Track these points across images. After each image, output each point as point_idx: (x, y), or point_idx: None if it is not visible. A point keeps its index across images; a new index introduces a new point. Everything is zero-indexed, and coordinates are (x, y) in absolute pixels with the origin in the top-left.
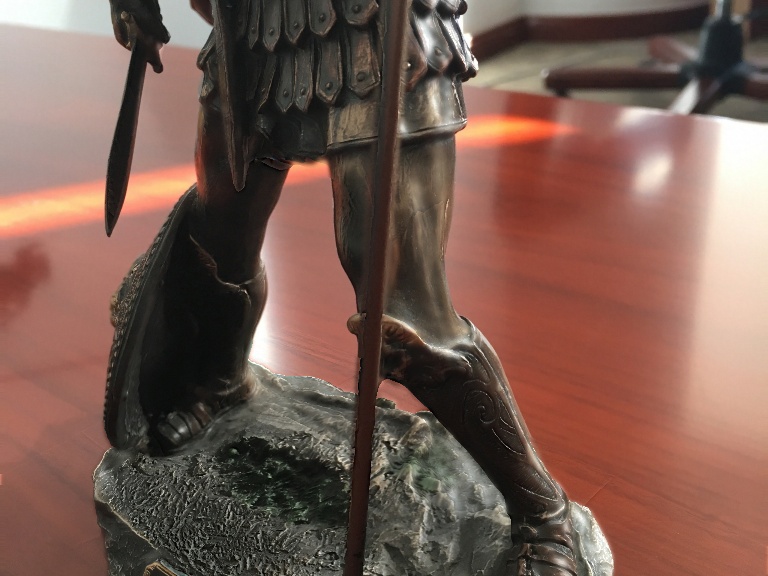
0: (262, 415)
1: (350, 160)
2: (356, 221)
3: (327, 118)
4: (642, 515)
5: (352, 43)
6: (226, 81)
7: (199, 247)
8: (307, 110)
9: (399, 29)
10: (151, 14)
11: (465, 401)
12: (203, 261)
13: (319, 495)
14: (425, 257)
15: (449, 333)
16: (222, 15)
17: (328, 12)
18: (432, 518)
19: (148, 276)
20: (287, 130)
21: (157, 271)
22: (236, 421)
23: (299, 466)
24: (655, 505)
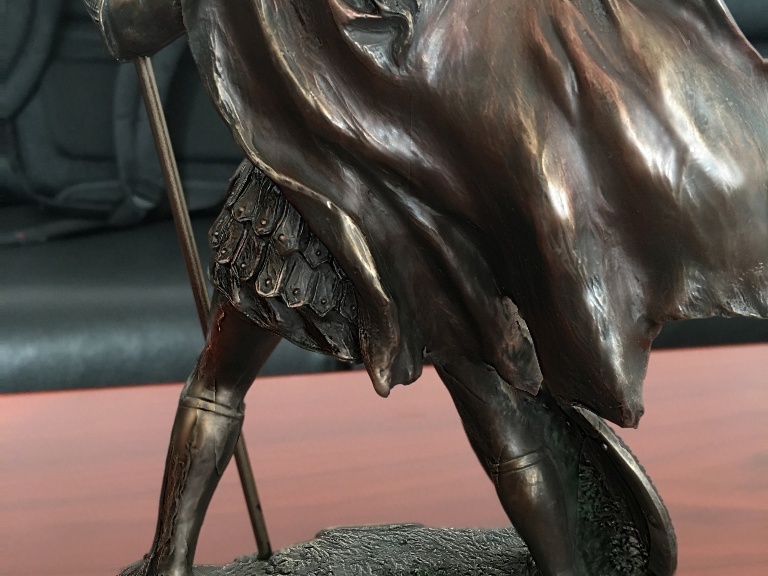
0: None
1: None
2: None
3: None
4: None
5: None
6: None
7: None
8: None
9: None
10: None
11: None
12: None
13: None
14: None
15: None
16: None
17: None
18: None
19: None
20: None
21: None
22: None
23: None
24: None
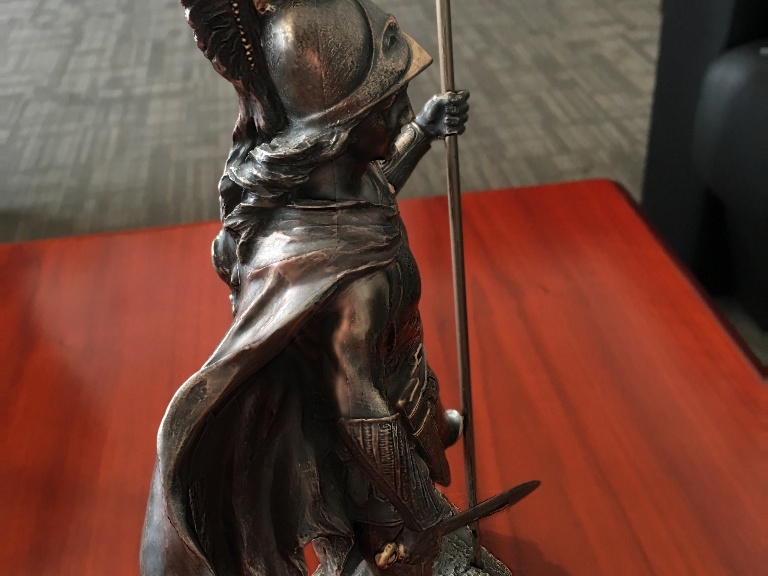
0: None
1: None
2: None
3: None
4: None
5: None
6: None
7: None
8: None
9: None
10: None
11: None
12: None
13: None
14: None
15: None
16: None
17: None
18: None
19: None
20: None
21: None
22: None
23: None
24: None
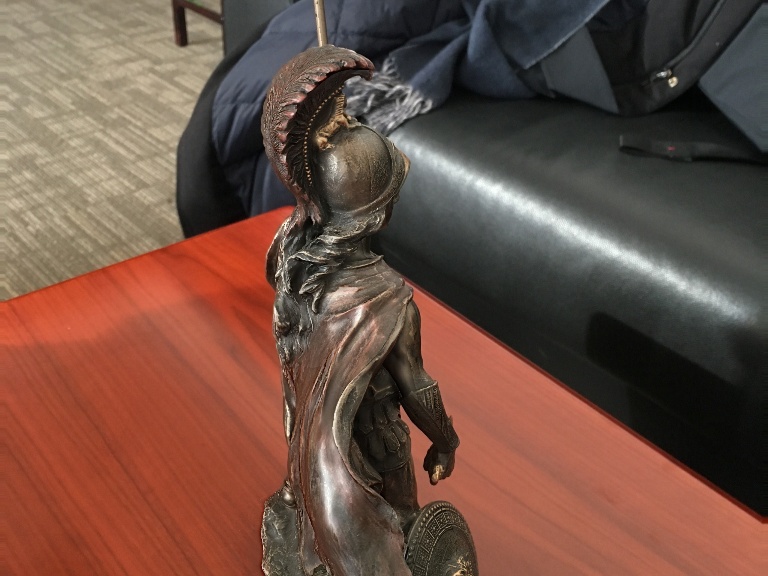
0: None
1: None
2: None
3: None
4: (216, 568)
5: None
6: None
7: None
8: None
9: None
10: None
11: None
12: None
13: None
14: None
15: None
16: None
17: None
18: None
19: None
20: None
21: None
22: None
23: None
24: (207, 570)
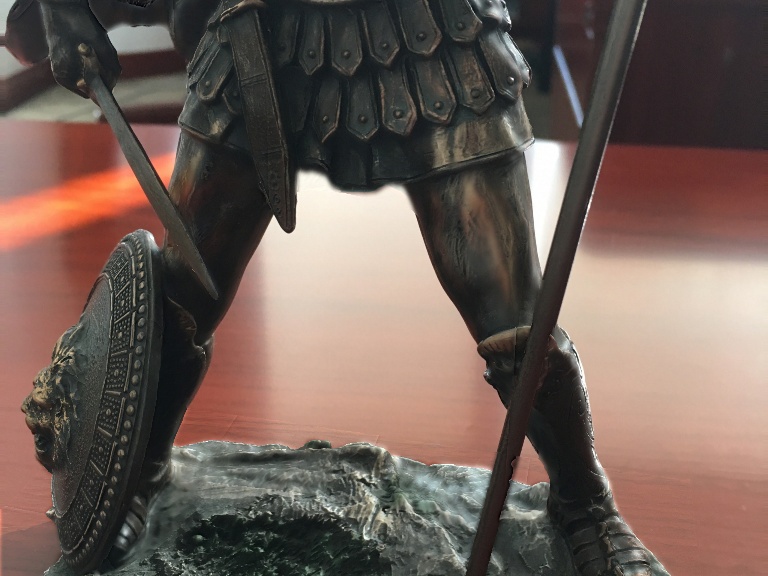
0: (204, 491)
1: (469, 179)
2: (478, 240)
3: (431, 139)
4: None
5: (455, 61)
6: (276, 112)
7: (182, 309)
8: (409, 133)
9: (630, 37)
10: (108, 46)
11: (572, 398)
12: (184, 325)
13: (326, 552)
14: (536, 265)
15: (558, 335)
16: (265, 40)
17: (431, 30)
18: (453, 537)
19: (149, 351)
20: (343, 160)
21: (157, 344)
22: (175, 506)
23: (284, 530)
24: None
